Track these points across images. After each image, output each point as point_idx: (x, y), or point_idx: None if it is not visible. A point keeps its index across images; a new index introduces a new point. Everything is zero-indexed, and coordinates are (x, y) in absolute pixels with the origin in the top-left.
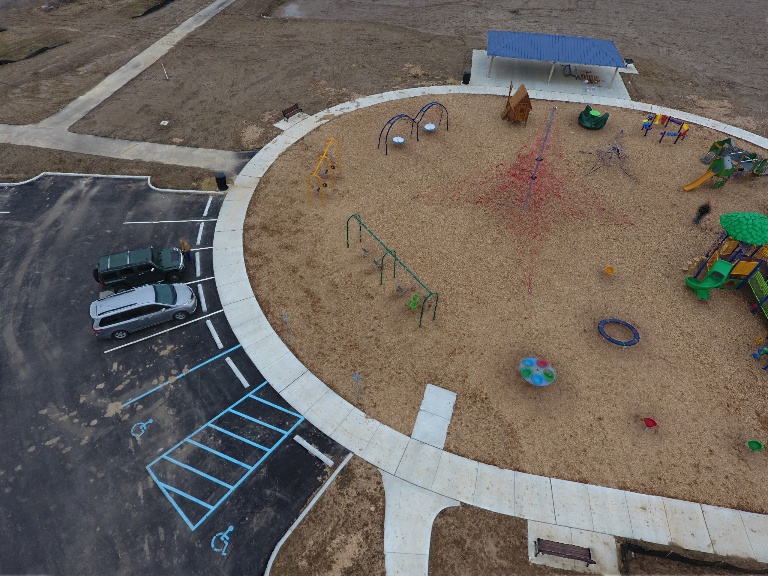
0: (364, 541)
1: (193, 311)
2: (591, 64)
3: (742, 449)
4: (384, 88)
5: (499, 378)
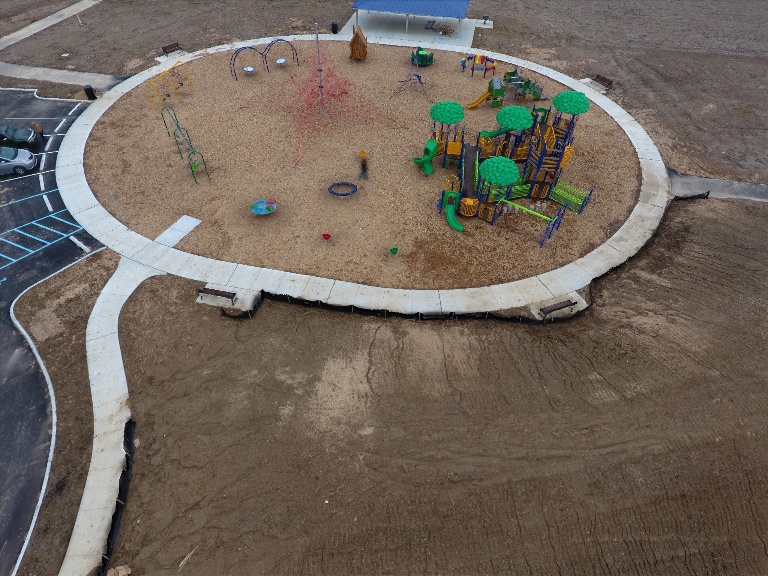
0: (89, 287)
1: (30, 168)
2: (436, 15)
3: (390, 255)
4: (262, 35)
5: (238, 213)
